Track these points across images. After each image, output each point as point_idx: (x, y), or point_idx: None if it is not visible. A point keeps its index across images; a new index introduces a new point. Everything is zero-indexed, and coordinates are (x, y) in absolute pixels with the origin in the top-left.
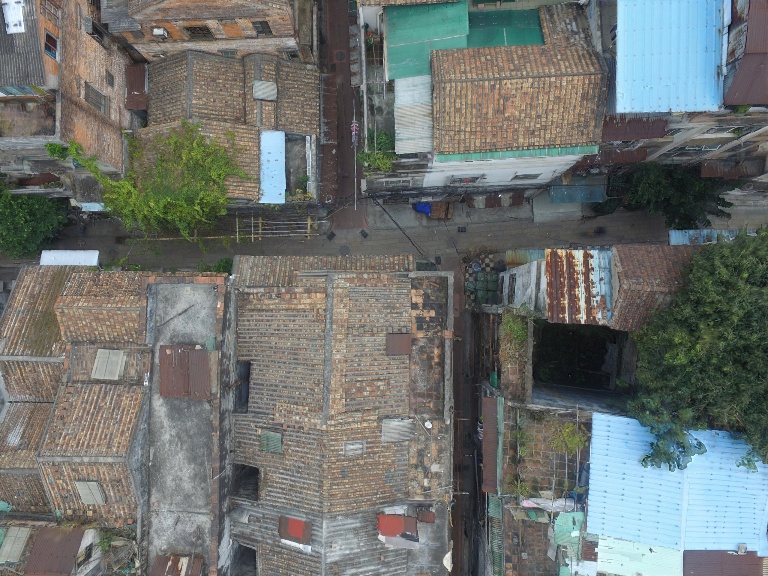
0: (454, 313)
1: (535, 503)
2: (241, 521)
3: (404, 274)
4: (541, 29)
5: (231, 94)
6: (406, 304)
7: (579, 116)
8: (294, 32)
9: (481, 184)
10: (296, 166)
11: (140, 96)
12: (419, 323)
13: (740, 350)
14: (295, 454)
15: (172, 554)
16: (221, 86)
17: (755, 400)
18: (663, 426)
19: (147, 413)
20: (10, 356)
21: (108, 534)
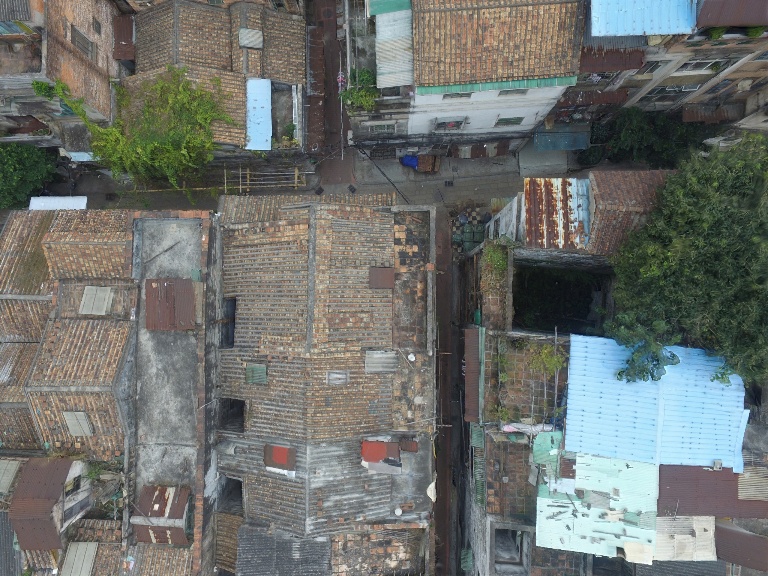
0: (437, 250)
1: (515, 428)
2: (227, 452)
3: (387, 208)
4: None
5: (217, 43)
6: (389, 239)
7: (557, 46)
8: None
9: (465, 131)
10: (283, 116)
11: (128, 46)
12: (402, 258)
13: (711, 260)
14: (280, 384)
15: (159, 485)
16: (207, 35)
17: (726, 308)
18: (637, 339)
19: (134, 347)
20: None
21: (97, 469)
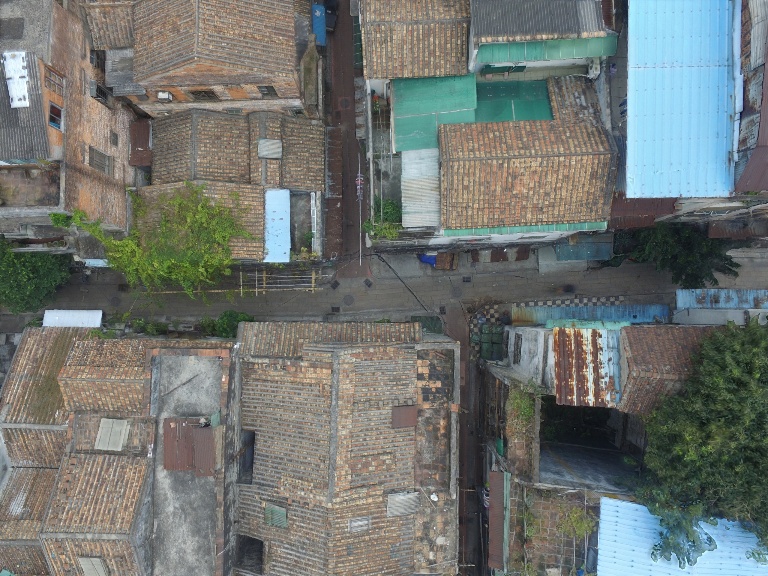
0: (460, 381)
1: None
2: None
3: (410, 346)
4: (549, 102)
5: (236, 151)
6: (412, 375)
7: (588, 194)
8: (300, 94)
9: (487, 242)
10: (301, 221)
11: (144, 152)
12: (425, 394)
13: (751, 448)
14: (300, 530)
15: None
16: (226, 144)
17: (767, 500)
18: (673, 520)
19: (151, 485)
20: (13, 424)
21: None
